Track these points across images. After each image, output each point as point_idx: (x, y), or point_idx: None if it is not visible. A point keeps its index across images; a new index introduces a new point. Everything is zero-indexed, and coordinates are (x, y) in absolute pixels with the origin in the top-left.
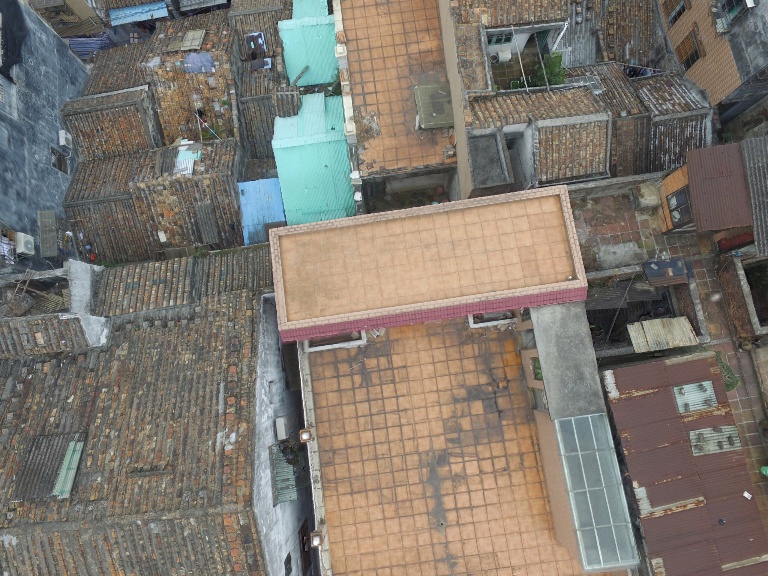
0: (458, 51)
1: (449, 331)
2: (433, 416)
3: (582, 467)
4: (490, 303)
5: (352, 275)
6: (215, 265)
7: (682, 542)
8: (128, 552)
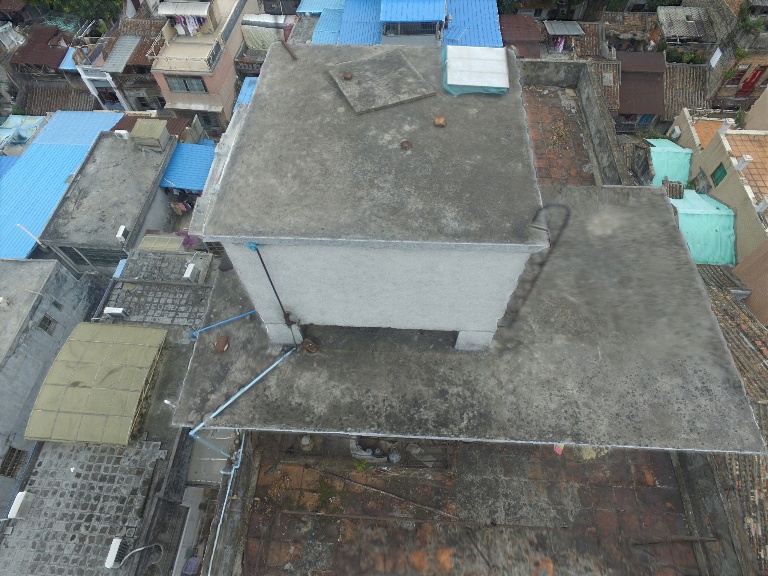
0: None
1: None
2: None
3: None
4: None
5: None
6: None
7: None
8: None
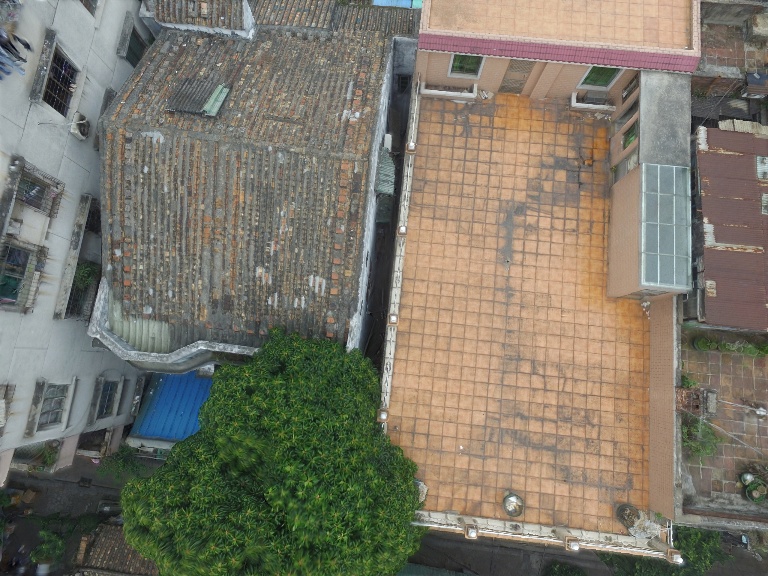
0: None
1: (550, 109)
2: (520, 174)
3: (658, 205)
4: (610, 52)
5: (492, 7)
6: (352, 13)
7: (736, 276)
8: (253, 175)
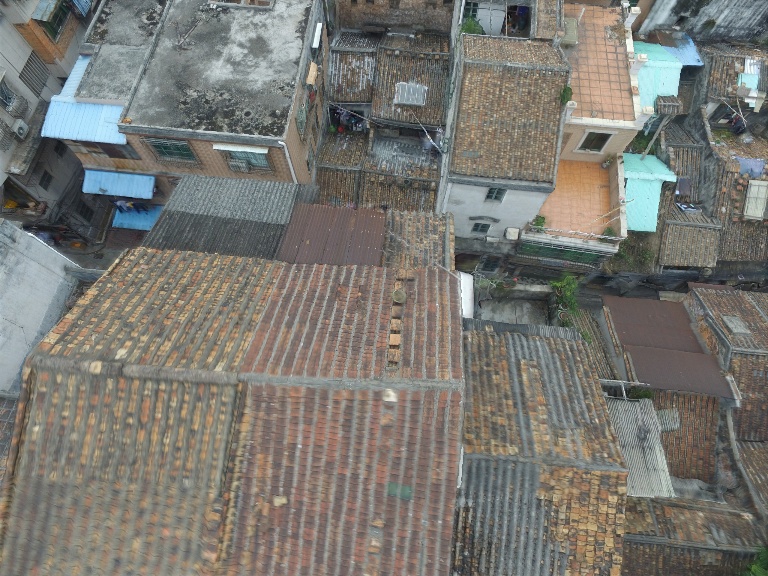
0: (562, 6)
1: None
2: None
3: None
4: None
5: None
6: None
7: None
8: None
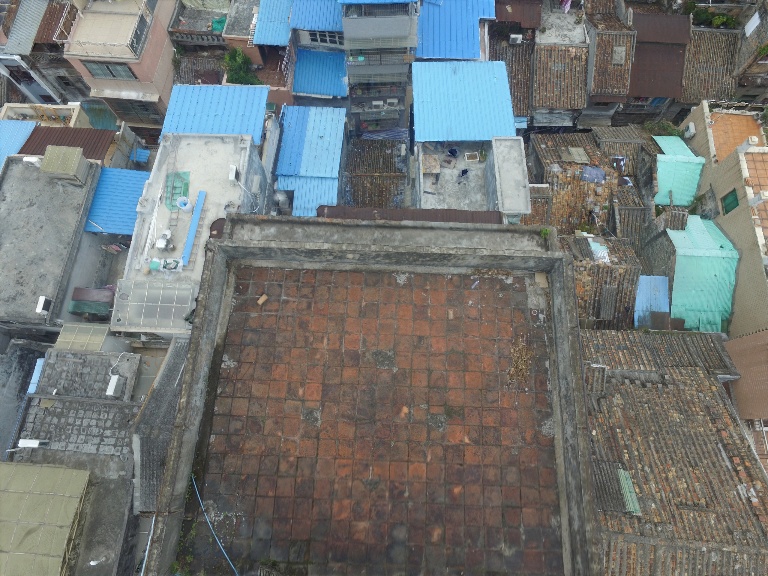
0: None
1: None
2: None
3: None
4: None
5: None
6: (658, 342)
7: None
8: (687, 573)
